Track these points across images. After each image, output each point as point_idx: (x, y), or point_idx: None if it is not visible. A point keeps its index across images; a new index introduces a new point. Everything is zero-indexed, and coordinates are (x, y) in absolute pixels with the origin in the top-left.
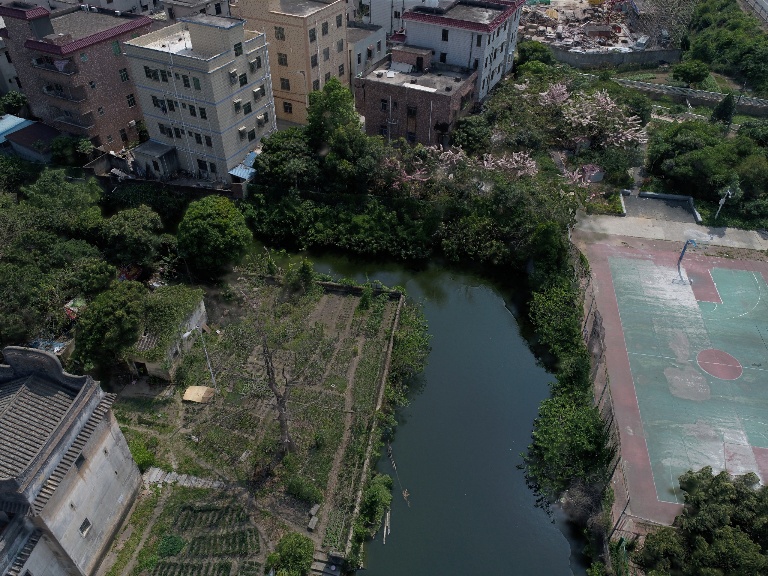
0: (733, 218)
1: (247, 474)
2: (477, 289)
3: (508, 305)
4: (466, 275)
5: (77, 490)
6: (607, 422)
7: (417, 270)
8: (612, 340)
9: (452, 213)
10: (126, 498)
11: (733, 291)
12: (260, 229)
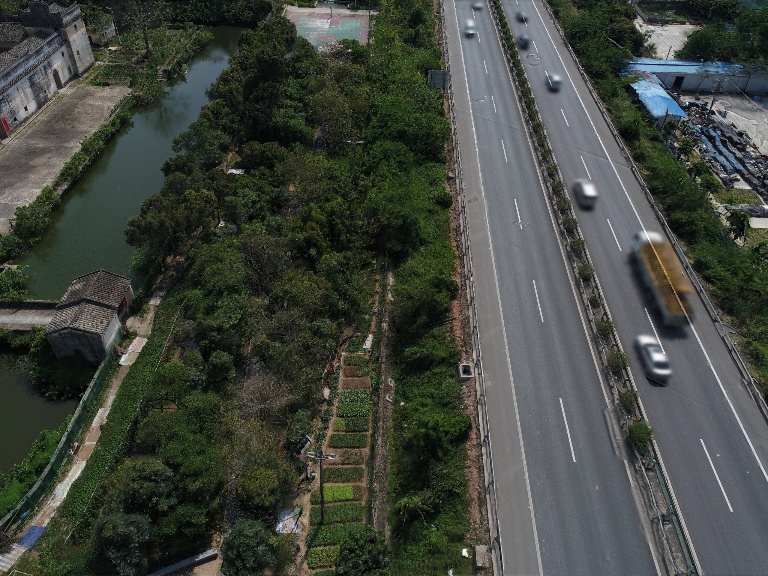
0: (363, 6)
1: None
2: None
3: None
4: (236, 27)
5: (75, 36)
6: None
7: (214, 26)
8: None
9: (230, 4)
10: (90, 61)
11: (346, 24)
12: None
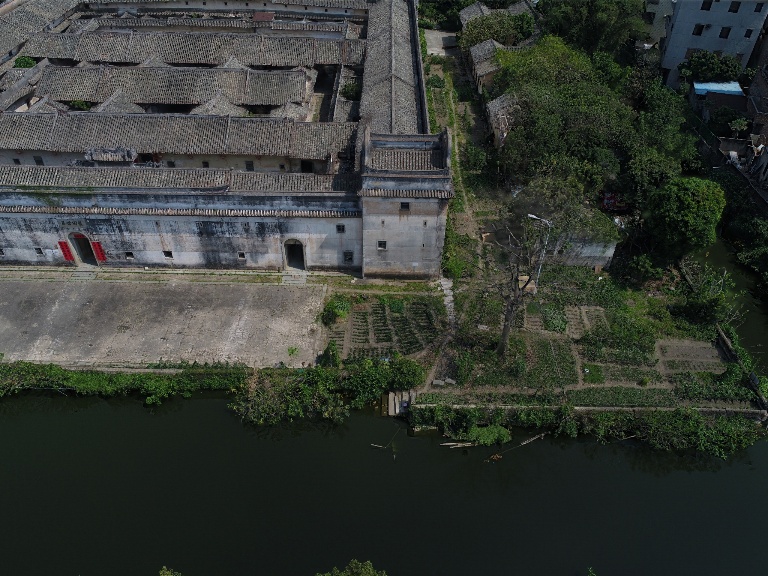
0: None
1: (467, 333)
2: None
3: None
4: None
5: (392, 219)
6: None
7: None
8: None
9: None
10: (419, 270)
11: None
12: (767, 273)
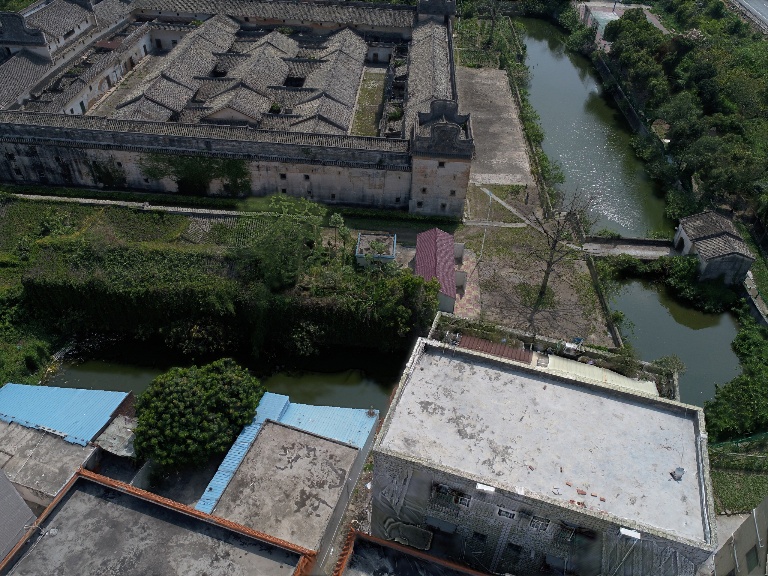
0: (634, 0)
1: None
2: (526, 41)
3: (549, 24)
4: (529, 18)
5: None
6: (593, 24)
7: None
8: (590, 25)
9: None
10: None
11: None
12: None
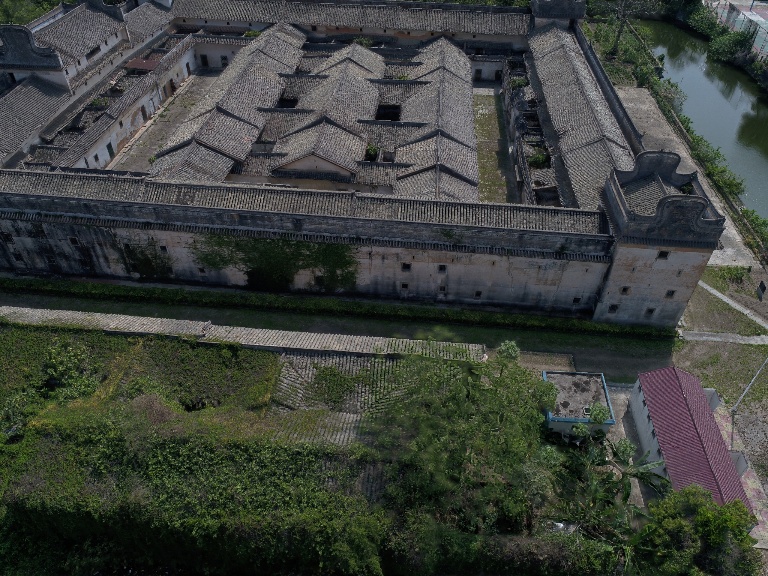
0: None
1: (603, 59)
2: None
3: (674, 28)
4: (647, 21)
5: None
6: (748, 27)
7: None
8: None
9: None
10: None
11: None
12: None
